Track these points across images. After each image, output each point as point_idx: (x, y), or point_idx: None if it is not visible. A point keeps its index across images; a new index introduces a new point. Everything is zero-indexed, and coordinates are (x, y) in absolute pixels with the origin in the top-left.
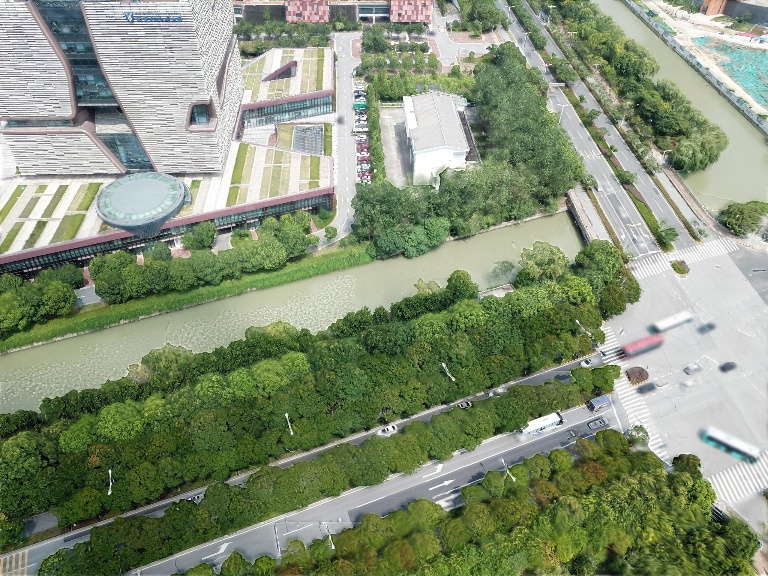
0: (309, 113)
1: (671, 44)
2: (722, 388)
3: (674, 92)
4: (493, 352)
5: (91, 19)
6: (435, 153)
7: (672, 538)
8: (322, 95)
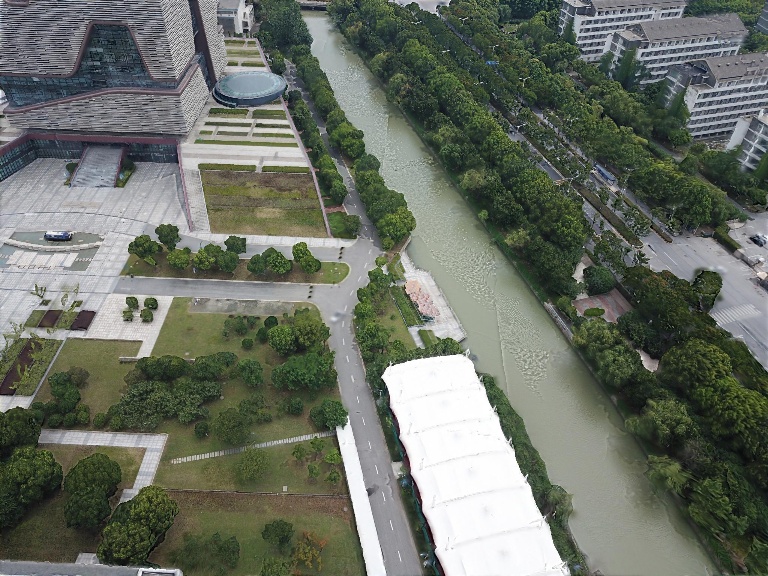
0: None
1: None
2: None
3: None
4: None
5: None
6: None
7: (483, 8)
8: None
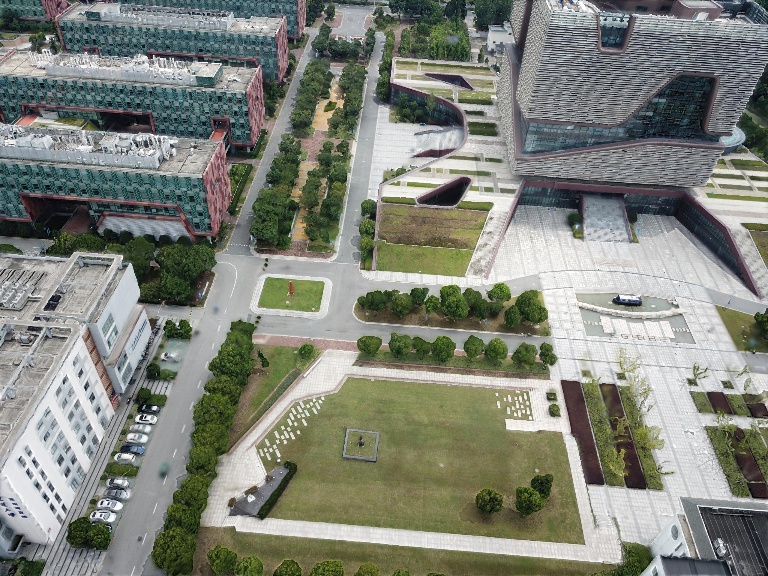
0: None
1: None
2: None
3: None
4: None
5: None
6: None
7: None
8: None
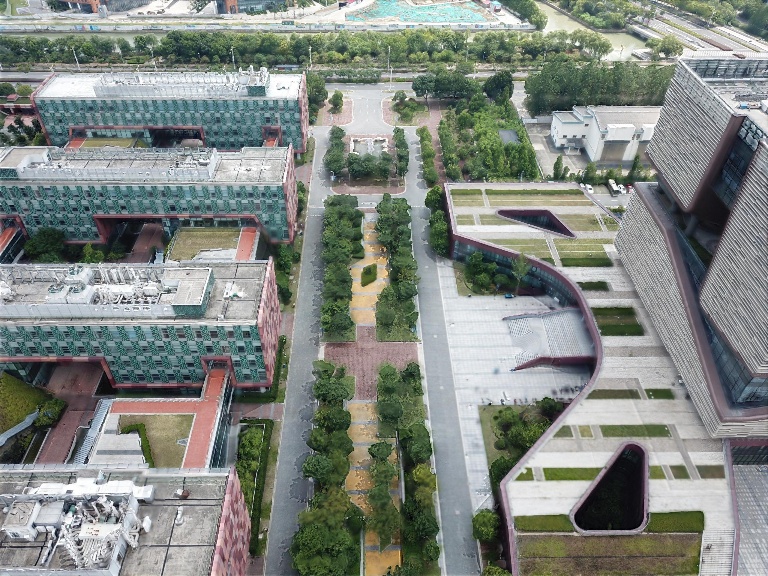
0: None
1: (357, 29)
2: None
3: (506, 33)
4: None
5: None
6: None
7: None
8: None
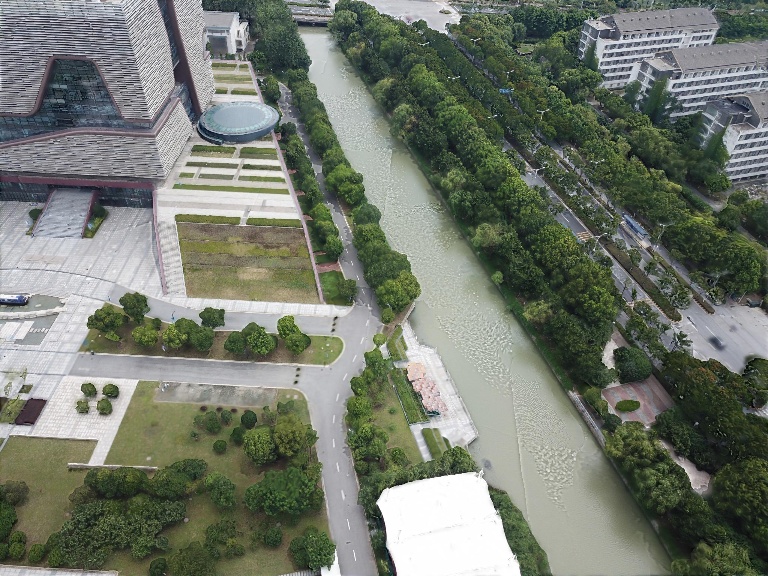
0: None
1: None
2: (419, 16)
3: None
4: None
5: None
6: (233, 24)
7: None
8: None
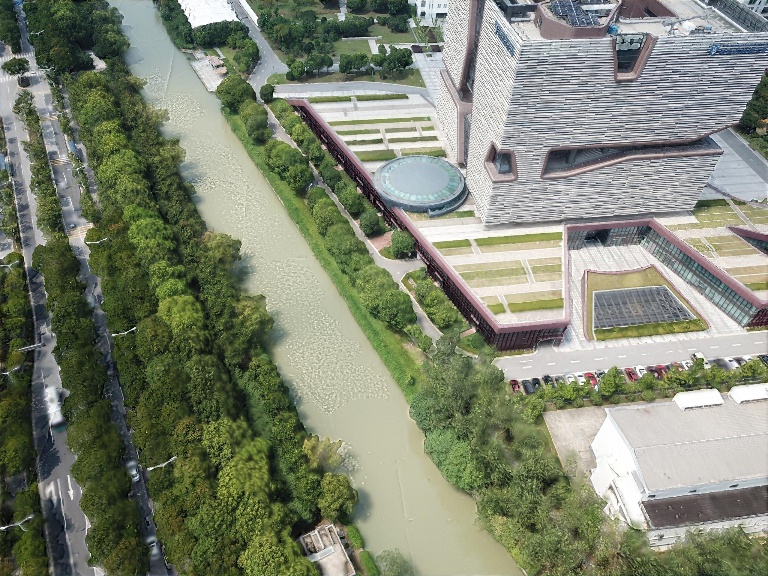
0: (716, 298)
1: None
2: None
3: None
4: (187, 517)
5: (485, 13)
6: None
7: None
8: (744, 295)
